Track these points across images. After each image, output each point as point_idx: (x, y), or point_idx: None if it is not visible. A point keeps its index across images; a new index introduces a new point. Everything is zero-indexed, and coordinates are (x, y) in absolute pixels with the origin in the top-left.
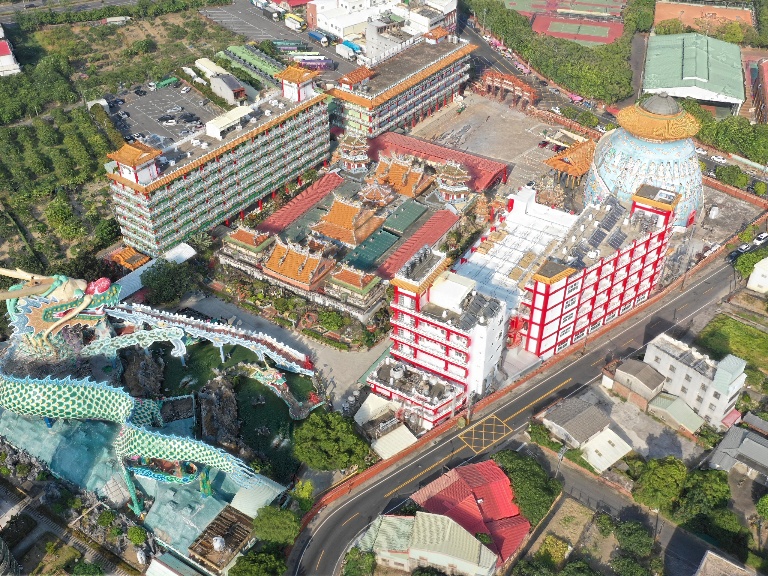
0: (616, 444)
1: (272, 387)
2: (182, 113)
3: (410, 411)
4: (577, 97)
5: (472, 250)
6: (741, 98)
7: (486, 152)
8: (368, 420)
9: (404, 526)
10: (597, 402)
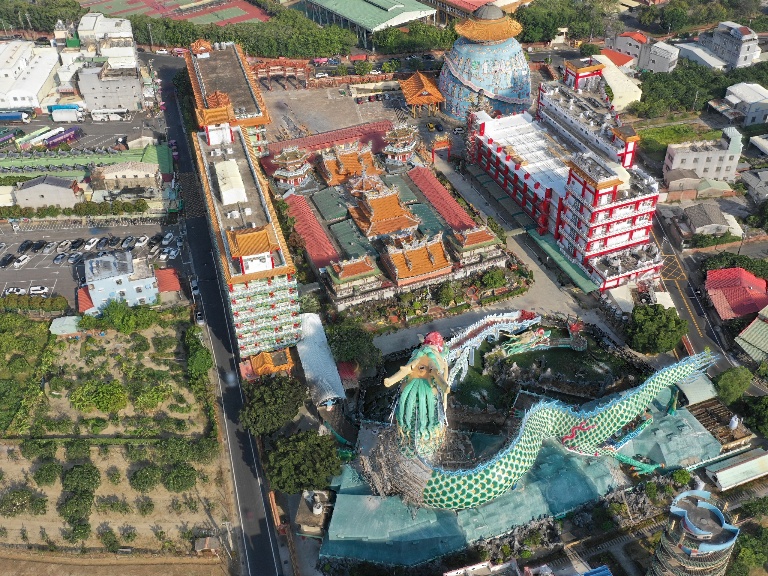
0: (727, 218)
1: (536, 347)
2: (12, 247)
3: (644, 280)
4: (324, 59)
5: (517, 167)
6: (433, 9)
7: (335, 126)
8: (633, 306)
9: (761, 328)
10: (673, 212)
